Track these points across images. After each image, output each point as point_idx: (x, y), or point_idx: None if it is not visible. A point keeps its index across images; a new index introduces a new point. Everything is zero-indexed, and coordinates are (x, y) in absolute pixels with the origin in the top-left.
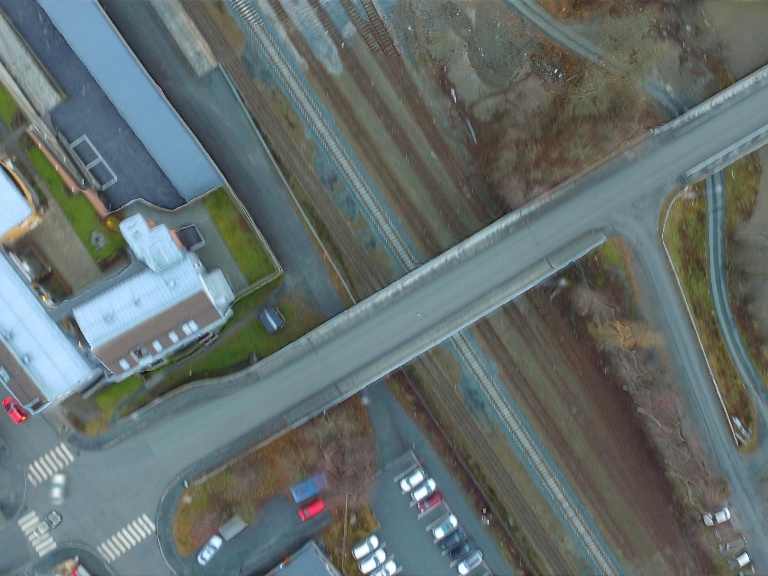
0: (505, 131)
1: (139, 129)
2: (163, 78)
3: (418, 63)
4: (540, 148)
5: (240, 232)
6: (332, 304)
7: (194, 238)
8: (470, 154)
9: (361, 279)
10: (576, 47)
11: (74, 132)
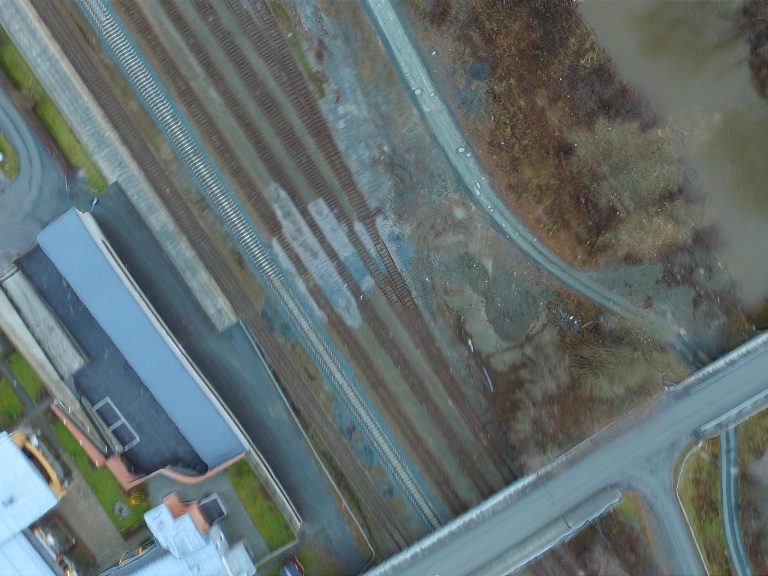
0: (522, 385)
1: (162, 398)
2: (184, 334)
3: (436, 313)
4: (557, 413)
5: (261, 499)
6: (350, 552)
7: (216, 513)
8: (487, 402)
9: (379, 526)
10: (591, 294)
11: (97, 394)
